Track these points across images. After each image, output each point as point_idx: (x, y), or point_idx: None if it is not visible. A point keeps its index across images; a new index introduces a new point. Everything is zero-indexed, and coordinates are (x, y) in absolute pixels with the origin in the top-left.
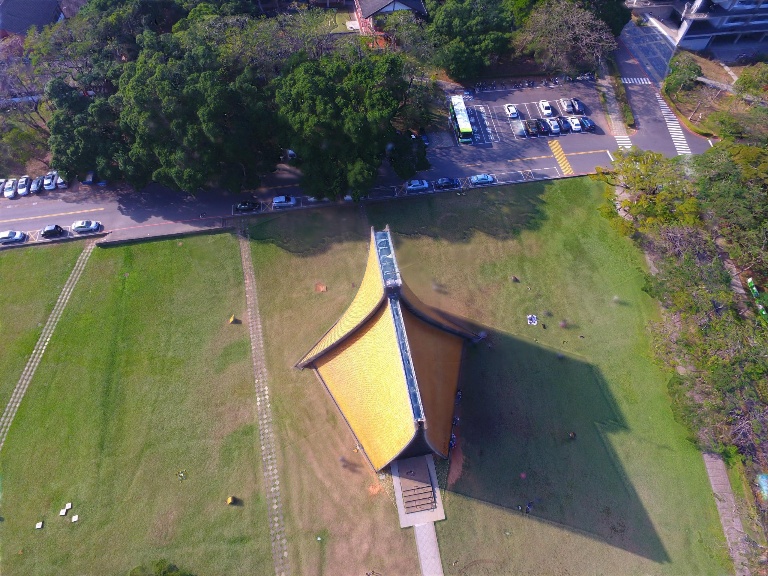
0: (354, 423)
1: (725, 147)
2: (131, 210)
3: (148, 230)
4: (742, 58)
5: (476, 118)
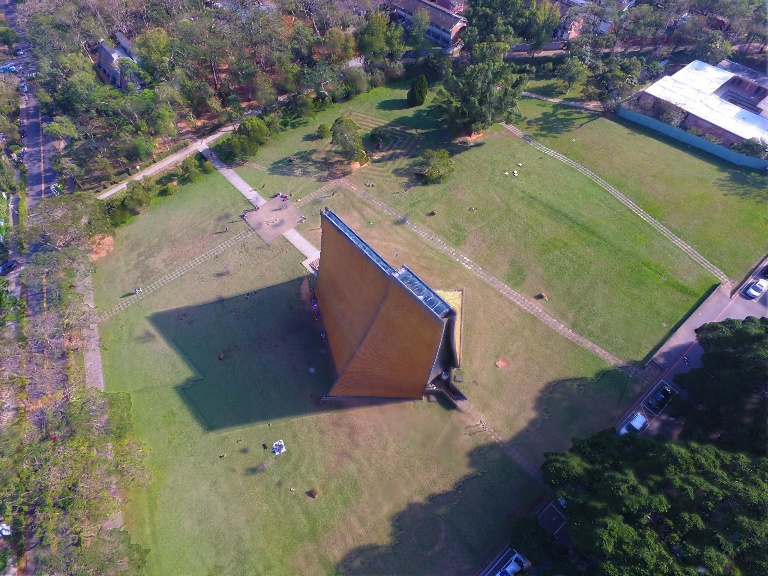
0: None
1: None
2: None
3: (707, 317)
4: None
5: None
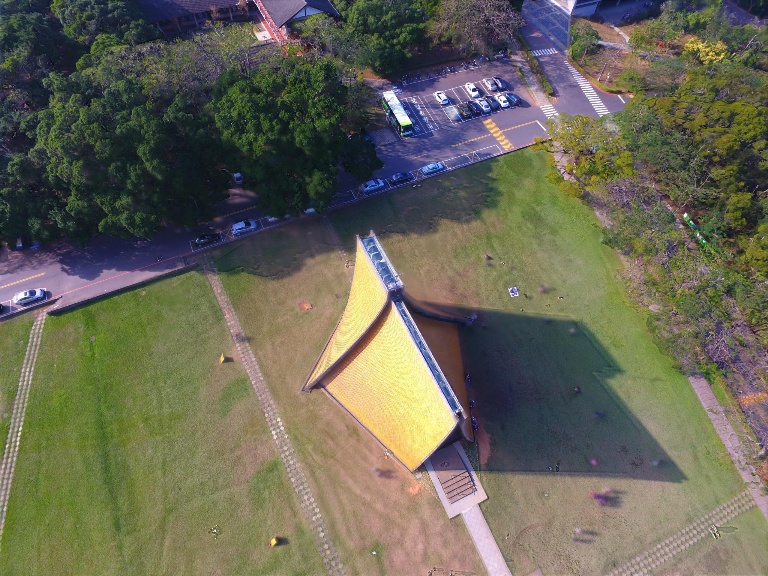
0: (378, 431)
1: (641, 101)
2: (77, 268)
3: (103, 286)
4: (627, 18)
5: (411, 110)
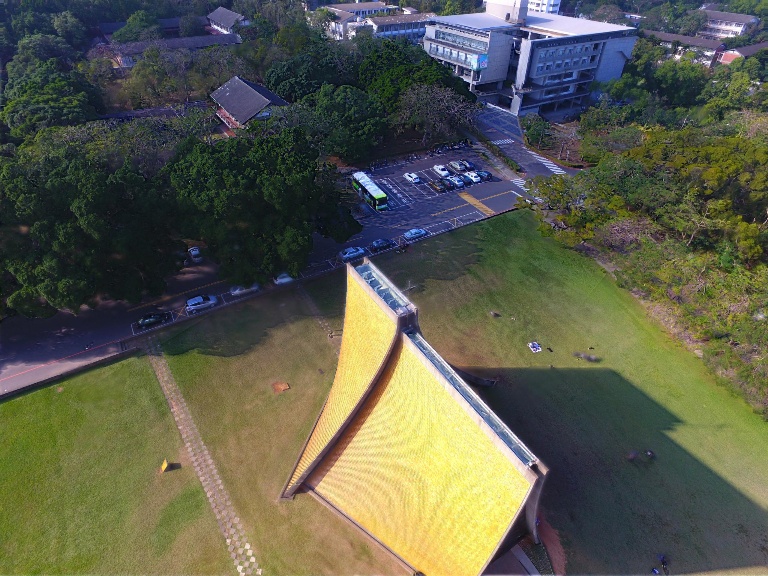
0: (398, 543)
1: None
2: None
3: (4, 385)
4: (567, 117)
5: (383, 189)
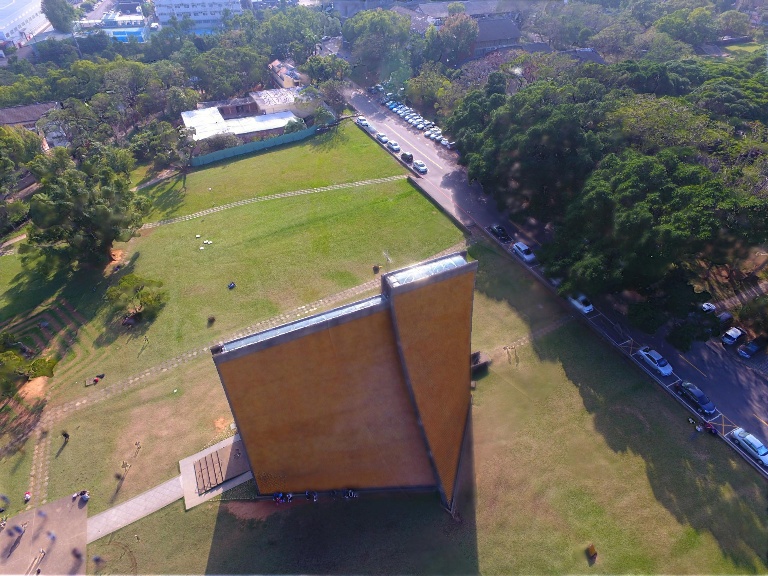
0: None
1: None
2: (449, 179)
3: (436, 192)
4: None
5: None
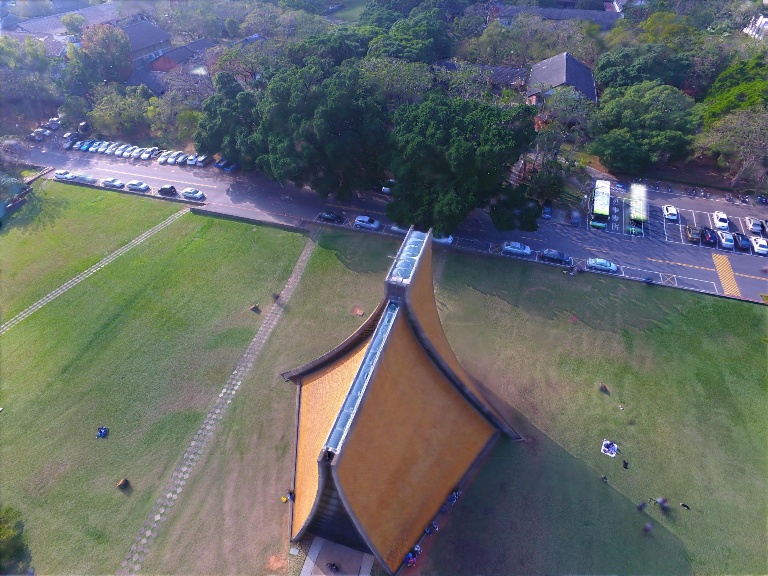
0: (301, 463)
1: None
2: (235, 193)
3: (237, 211)
4: None
5: (621, 209)
